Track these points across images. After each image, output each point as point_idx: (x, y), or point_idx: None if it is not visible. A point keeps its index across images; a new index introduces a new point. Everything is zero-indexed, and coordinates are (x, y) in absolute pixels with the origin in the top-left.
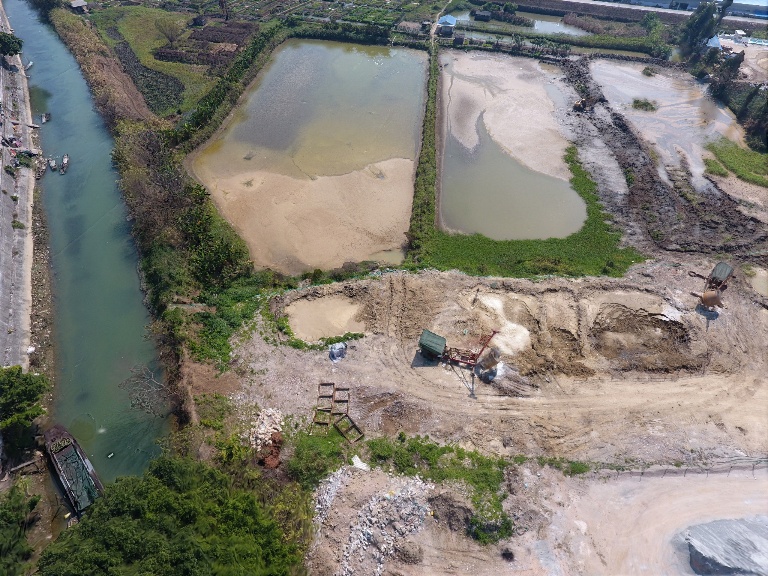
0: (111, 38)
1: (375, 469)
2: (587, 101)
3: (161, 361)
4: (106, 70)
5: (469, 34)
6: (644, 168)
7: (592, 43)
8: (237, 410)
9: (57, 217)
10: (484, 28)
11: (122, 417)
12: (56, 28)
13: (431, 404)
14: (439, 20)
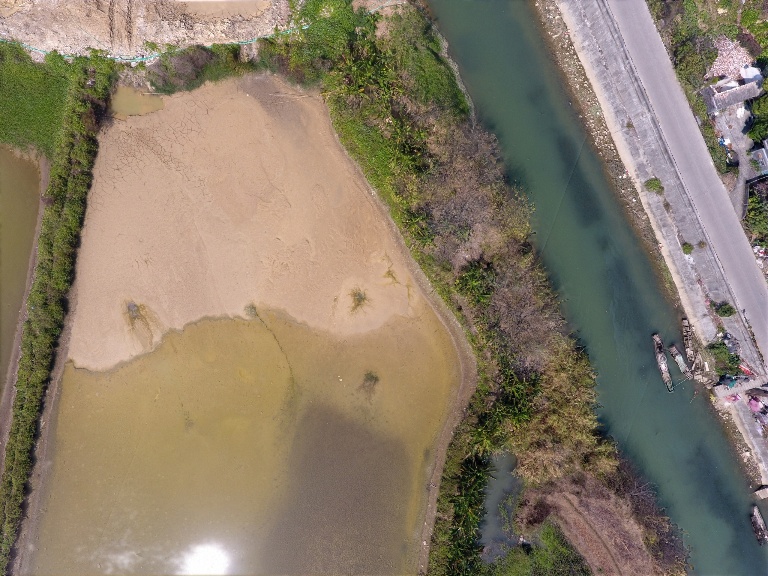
0: None
1: None
2: None
3: None
4: None
5: None
6: None
7: None
8: None
9: (617, 222)
10: None
11: None
12: None
13: None
14: None
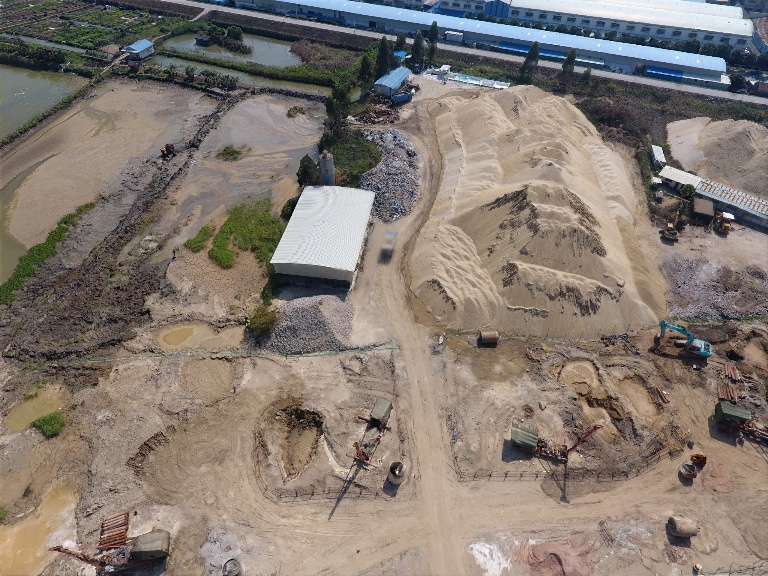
0: None
1: None
2: None
3: None
4: None
5: (176, 60)
6: (112, 237)
7: (281, 75)
8: None
9: None
10: (184, 54)
11: None
12: None
13: None
14: (130, 45)
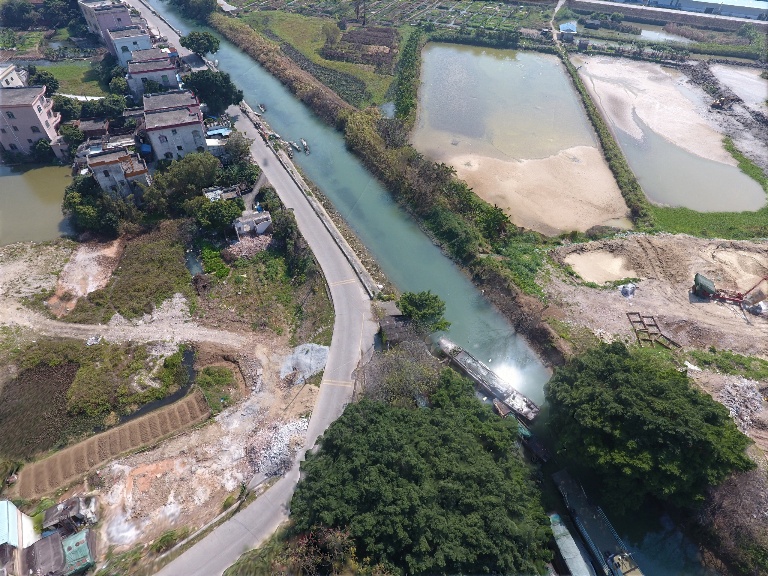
0: (271, 40)
1: (706, 370)
2: None
3: (485, 297)
4: None
5: None
6: None
7: (703, 50)
8: (573, 330)
9: (328, 188)
10: (599, 35)
11: (481, 335)
12: (221, 30)
13: (721, 329)
14: (561, 27)
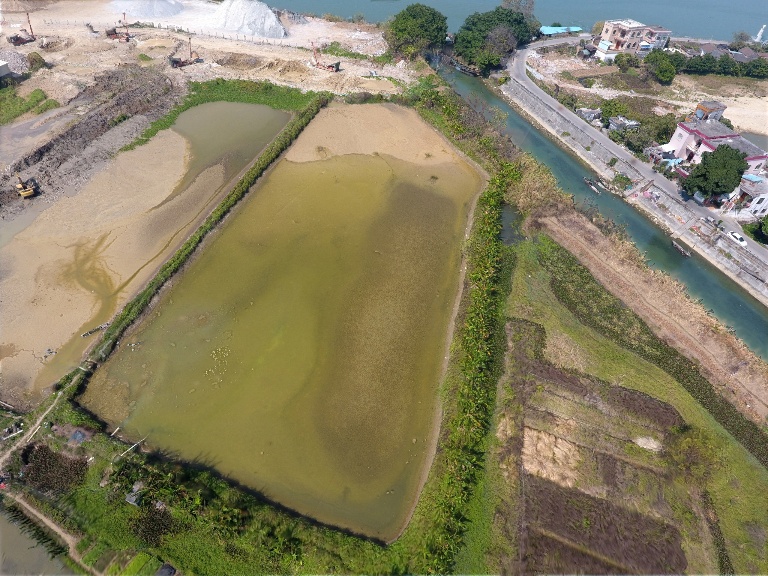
0: None
1: None
2: (1, 201)
3: None
4: (709, 341)
5: None
6: (105, 113)
7: None
8: None
9: None
10: None
11: None
12: None
13: (341, 62)
14: None
